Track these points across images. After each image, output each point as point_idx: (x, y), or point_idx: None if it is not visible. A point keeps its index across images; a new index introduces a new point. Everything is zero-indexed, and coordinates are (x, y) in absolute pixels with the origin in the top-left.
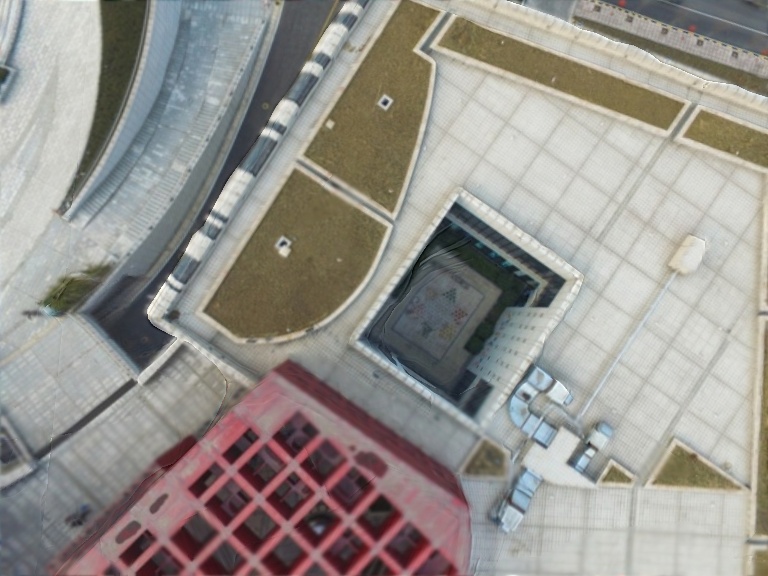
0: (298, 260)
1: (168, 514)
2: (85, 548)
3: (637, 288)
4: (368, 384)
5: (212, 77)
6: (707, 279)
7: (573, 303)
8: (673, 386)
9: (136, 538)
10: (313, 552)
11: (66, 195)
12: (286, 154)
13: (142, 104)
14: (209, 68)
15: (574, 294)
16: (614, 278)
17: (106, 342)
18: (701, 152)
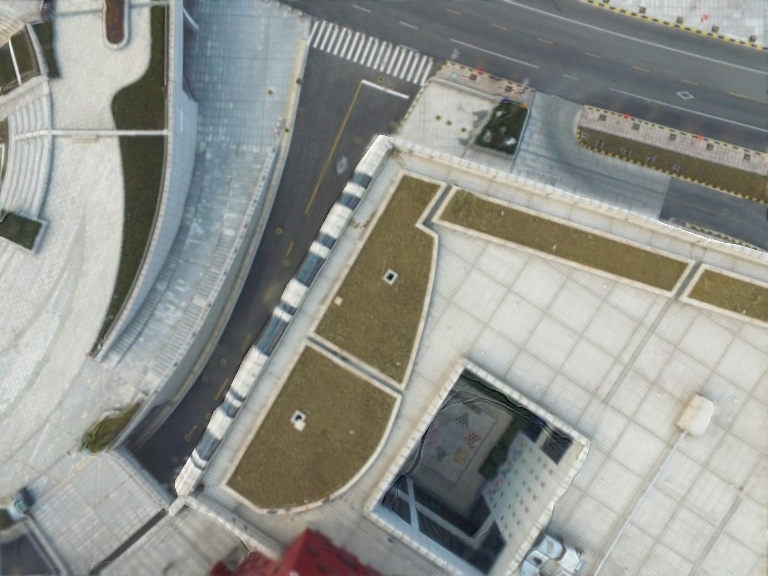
0: (312, 433)
1: None
2: None
3: (645, 448)
4: (383, 549)
5: (228, 209)
6: (717, 437)
7: None
8: (685, 545)
9: None
10: None
11: (97, 337)
12: (298, 330)
13: (163, 244)
14: (224, 199)
15: (581, 461)
16: (622, 439)
17: (139, 474)
18: (707, 310)
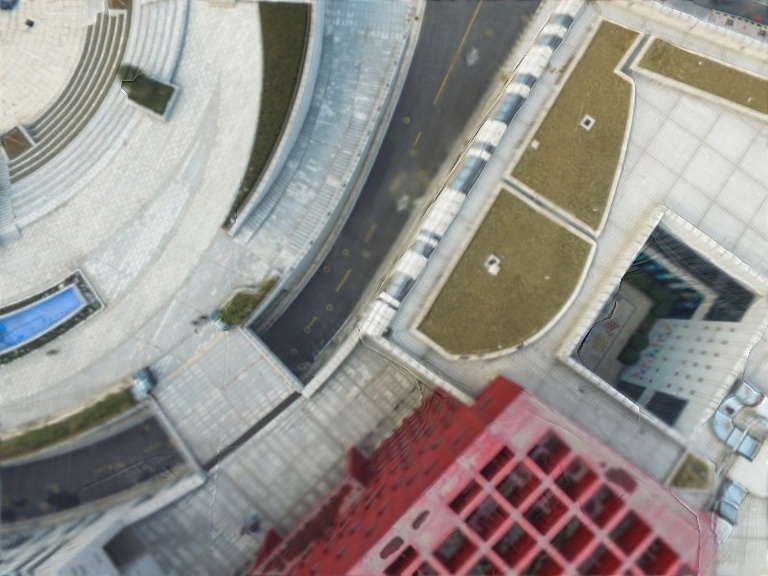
0: (507, 278)
1: (430, 530)
2: (290, 560)
3: None
4: (574, 399)
5: (358, 92)
6: None
7: None
8: None
9: (400, 554)
10: (569, 566)
11: (230, 211)
12: (491, 174)
13: (298, 120)
14: (354, 83)
15: None
16: None
17: (270, 355)
18: None
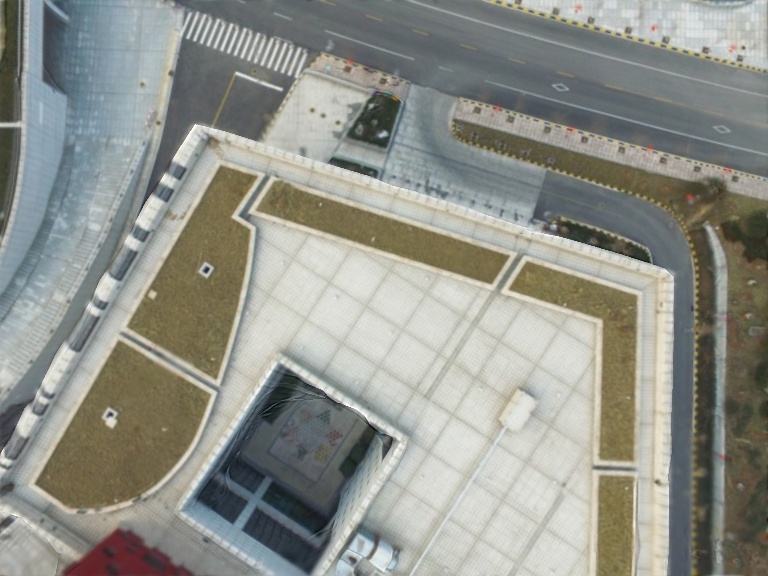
0: (124, 431)
1: None
2: None
3: (467, 444)
4: (198, 549)
5: (94, 203)
6: (540, 432)
7: (396, 466)
8: (507, 542)
9: None
10: None
11: None
12: (112, 324)
13: (21, 239)
14: (91, 194)
15: (396, 458)
16: (443, 435)
17: None
18: (529, 303)
